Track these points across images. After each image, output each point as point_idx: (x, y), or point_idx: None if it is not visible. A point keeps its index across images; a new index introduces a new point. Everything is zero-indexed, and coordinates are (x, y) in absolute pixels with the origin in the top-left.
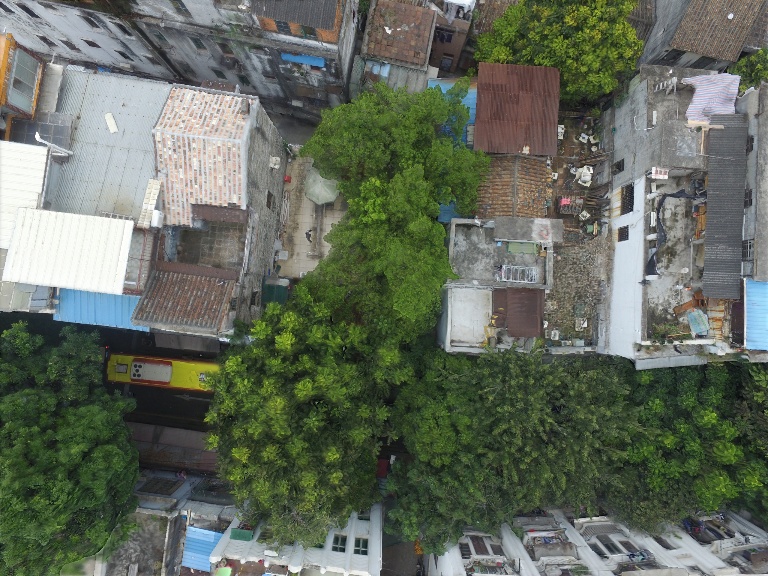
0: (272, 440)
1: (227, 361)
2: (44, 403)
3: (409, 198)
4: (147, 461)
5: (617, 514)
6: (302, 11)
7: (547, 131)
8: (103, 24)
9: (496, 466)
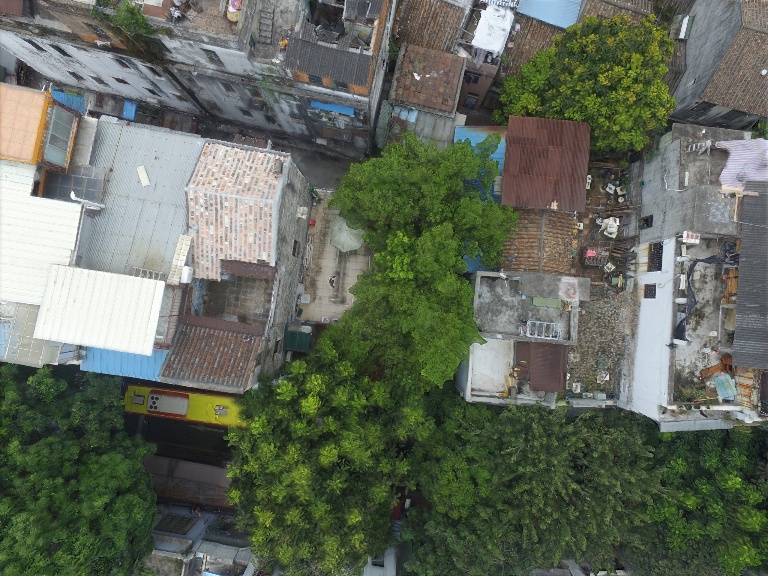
0: (295, 503)
1: (253, 423)
2: (67, 452)
3: (438, 257)
4: (161, 495)
5: (634, 569)
6: (336, 67)
7: (576, 187)
8: (134, 66)
9: (515, 523)
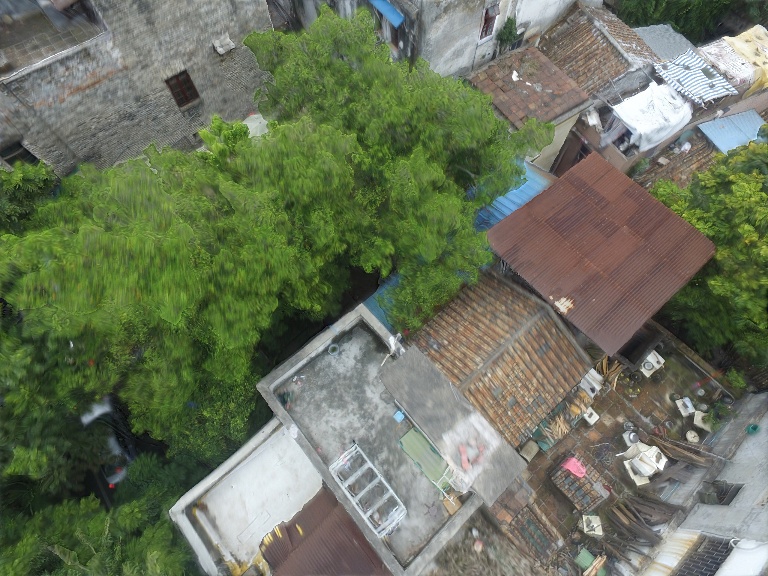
0: None
1: None
2: None
3: None
4: None
5: None
6: None
7: (625, 308)
8: None
9: None
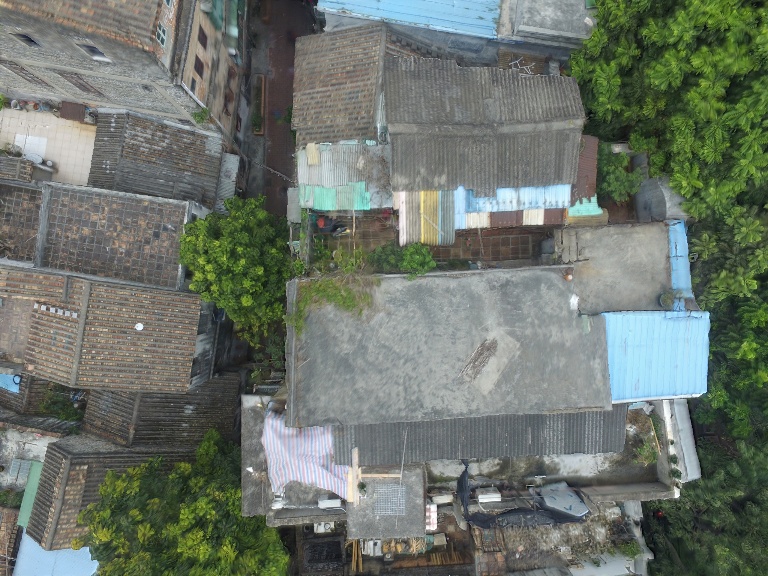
0: None
1: None
2: None
3: None
4: None
5: None
6: None
7: None
8: None
9: None
